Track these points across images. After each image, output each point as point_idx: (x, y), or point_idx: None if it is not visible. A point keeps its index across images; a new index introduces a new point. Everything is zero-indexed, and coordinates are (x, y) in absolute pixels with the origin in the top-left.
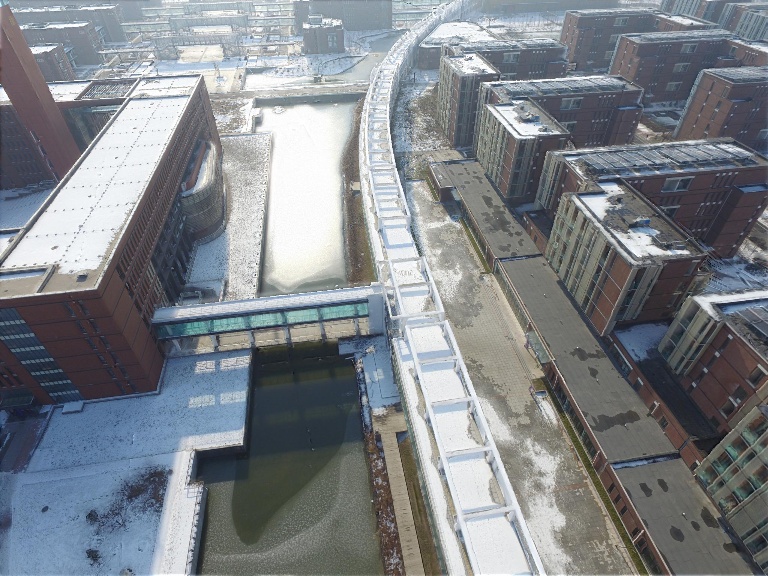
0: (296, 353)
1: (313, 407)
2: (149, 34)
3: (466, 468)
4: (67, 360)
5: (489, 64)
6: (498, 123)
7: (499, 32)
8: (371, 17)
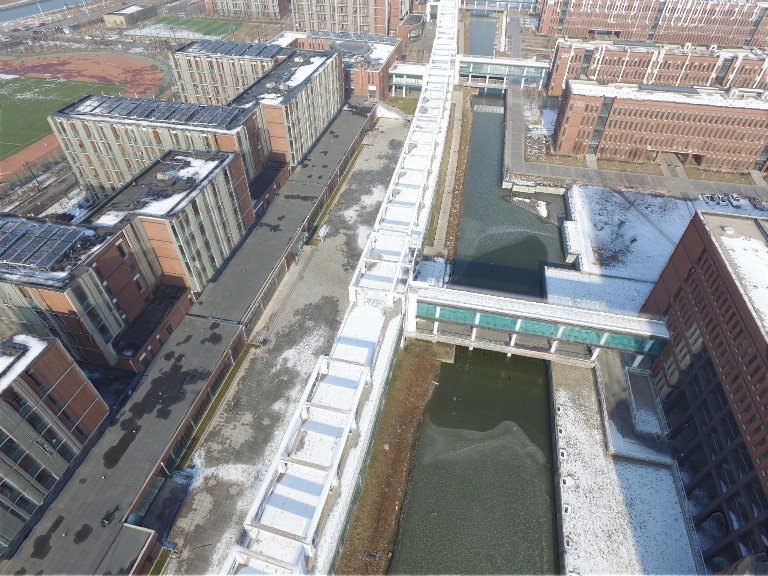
0: None
1: (489, 287)
2: None
3: (412, 182)
4: None
5: None
6: None
7: None
8: None
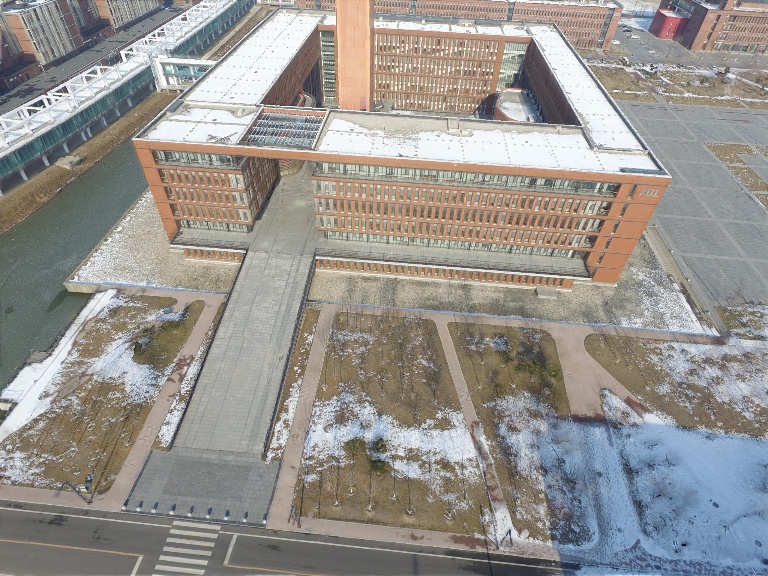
0: None
1: None
2: None
3: None
4: None
5: None
6: None
7: None
8: None
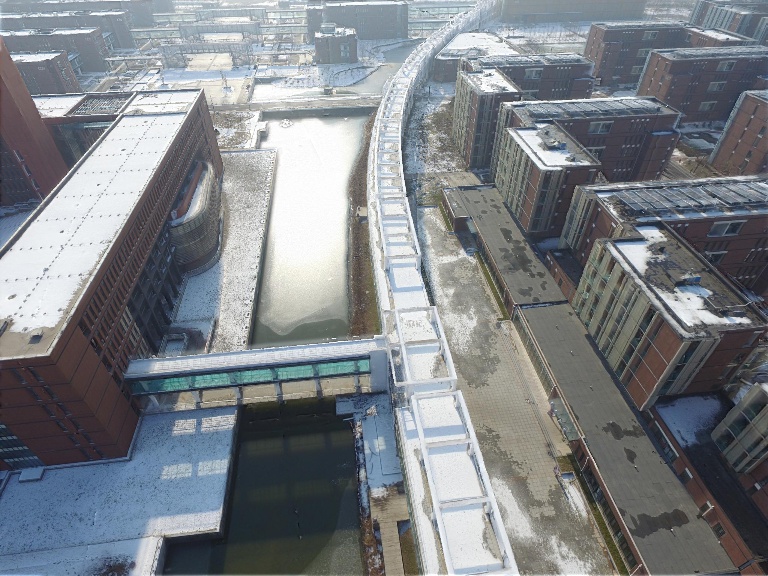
0: (288, 410)
1: (303, 481)
2: (159, 40)
3: None
4: (21, 427)
5: (510, 81)
6: (520, 150)
7: (519, 43)
8: (386, 26)
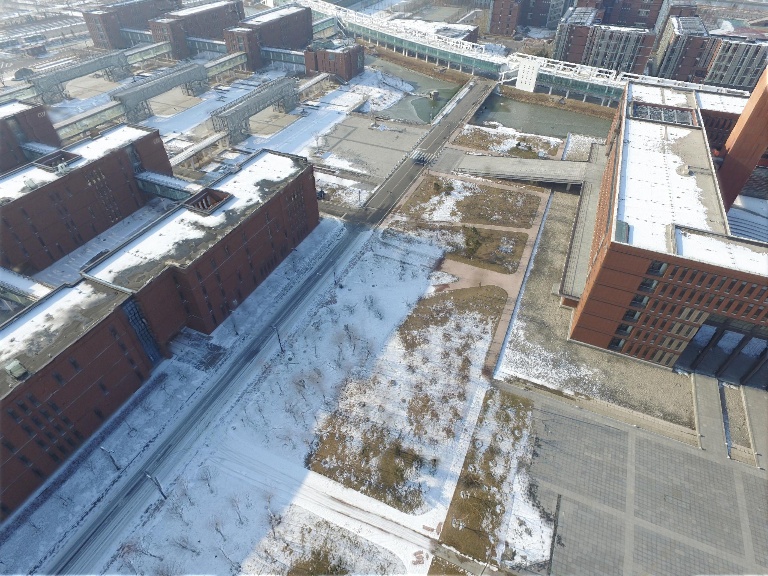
0: None
1: None
2: None
3: None
4: None
5: None
6: (757, 47)
7: None
8: (300, 35)
